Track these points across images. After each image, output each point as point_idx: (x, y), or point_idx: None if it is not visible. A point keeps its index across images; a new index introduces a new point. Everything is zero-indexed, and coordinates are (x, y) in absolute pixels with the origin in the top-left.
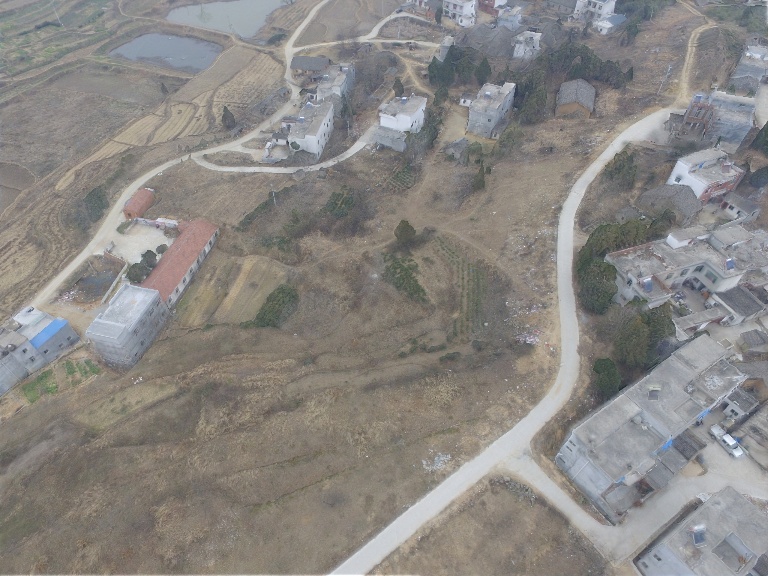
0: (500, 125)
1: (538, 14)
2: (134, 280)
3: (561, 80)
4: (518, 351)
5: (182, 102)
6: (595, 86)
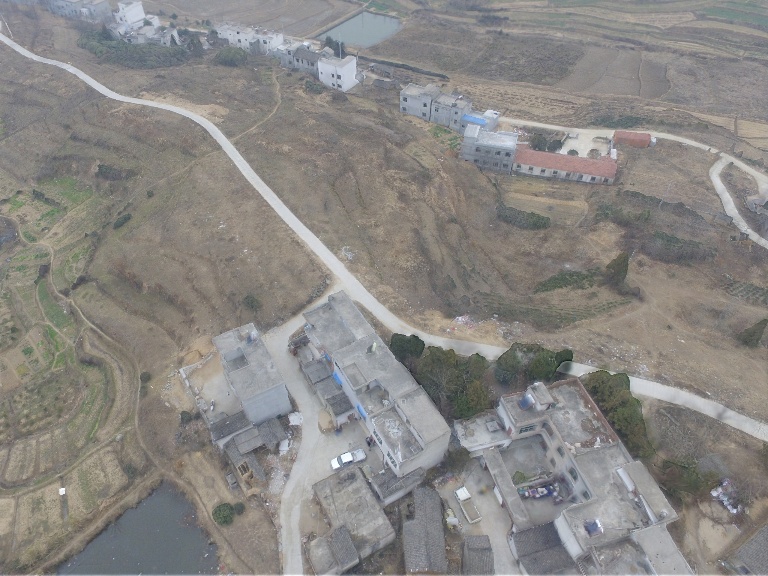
0: None
1: None
2: (531, 144)
3: None
4: None
5: None
6: None
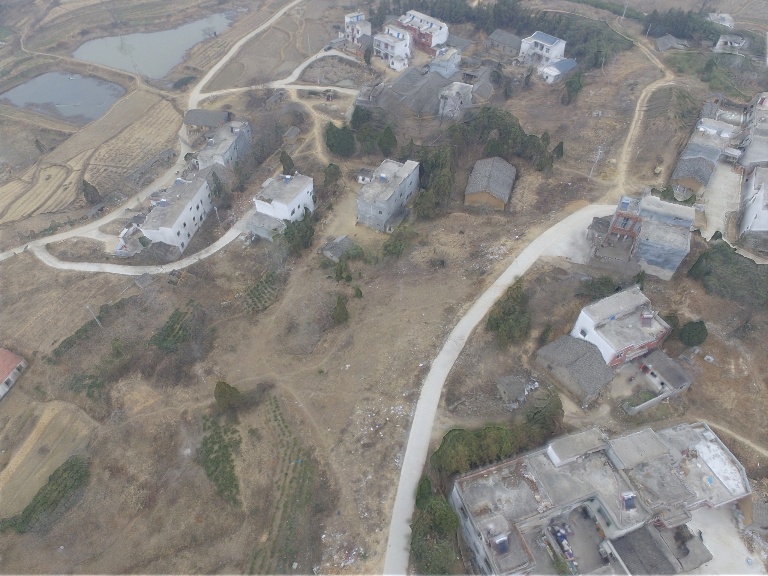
0: (396, 216)
1: (481, 55)
2: None
3: (478, 154)
4: None
5: (55, 164)
6: (516, 165)
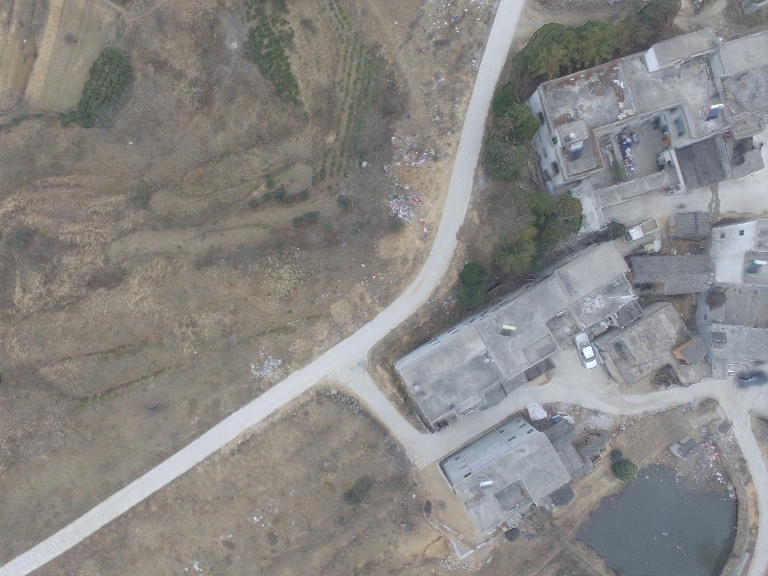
0: None
1: None
2: None
3: None
4: (386, 226)
5: None
6: None
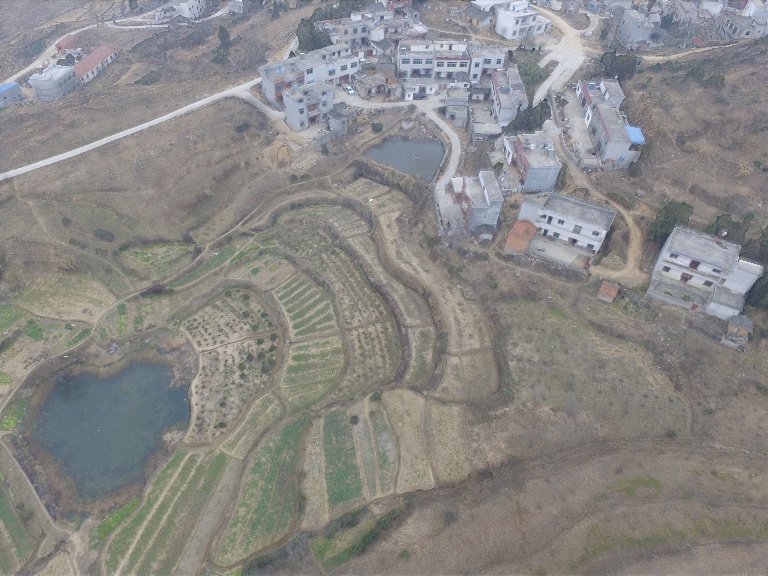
0: None
1: None
2: None
3: None
4: (260, 65)
5: (103, 0)
6: None
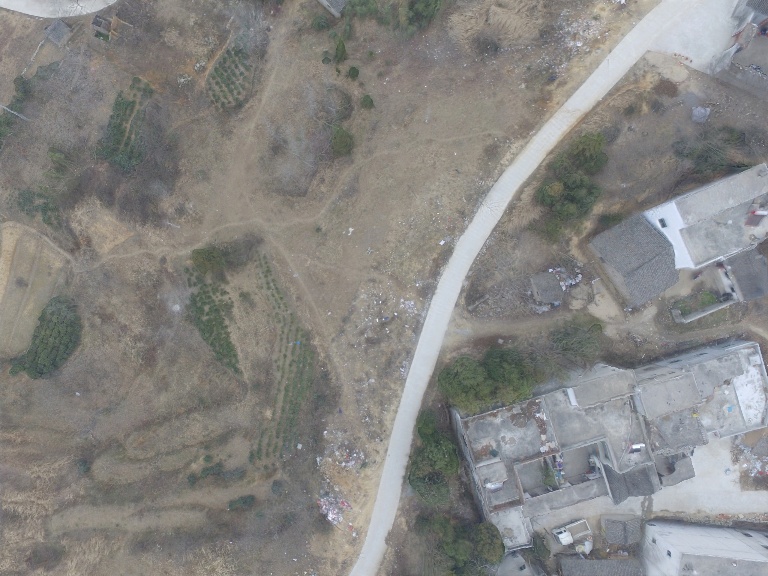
0: None
1: None
2: None
3: None
4: (316, 525)
5: None
6: None
